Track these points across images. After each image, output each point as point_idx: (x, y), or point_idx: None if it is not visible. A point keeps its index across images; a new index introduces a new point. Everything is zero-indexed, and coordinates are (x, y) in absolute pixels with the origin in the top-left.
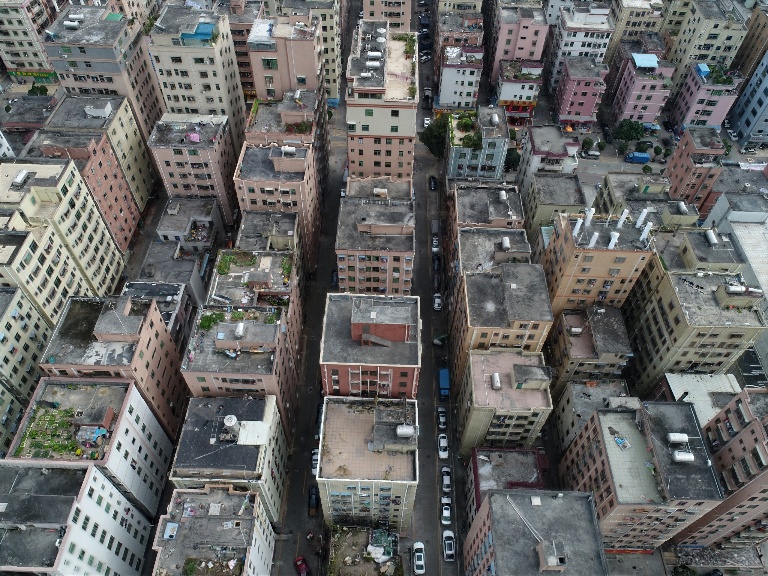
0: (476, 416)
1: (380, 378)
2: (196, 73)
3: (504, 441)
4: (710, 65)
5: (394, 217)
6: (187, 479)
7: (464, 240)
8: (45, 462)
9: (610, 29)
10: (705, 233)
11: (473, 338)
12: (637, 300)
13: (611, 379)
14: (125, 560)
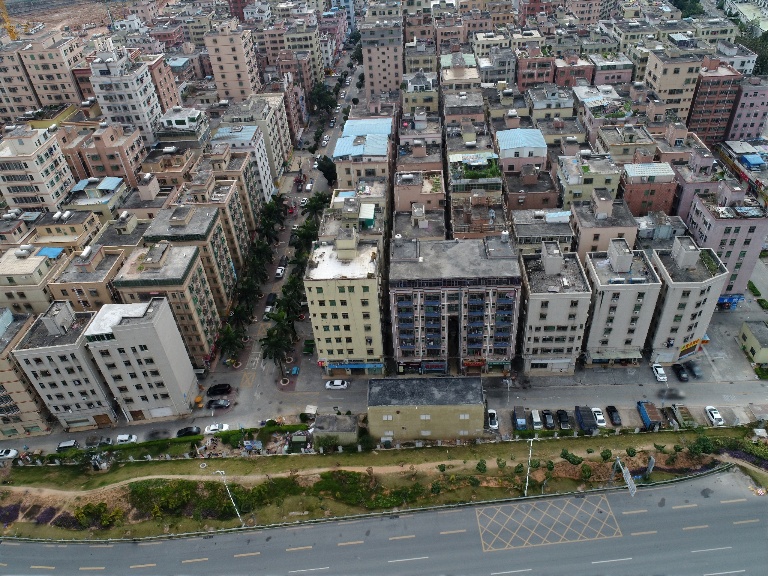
0: None
1: None
2: None
3: None
4: None
5: None
6: None
7: None
8: None
9: None
10: None
11: None
12: None
13: None
14: None
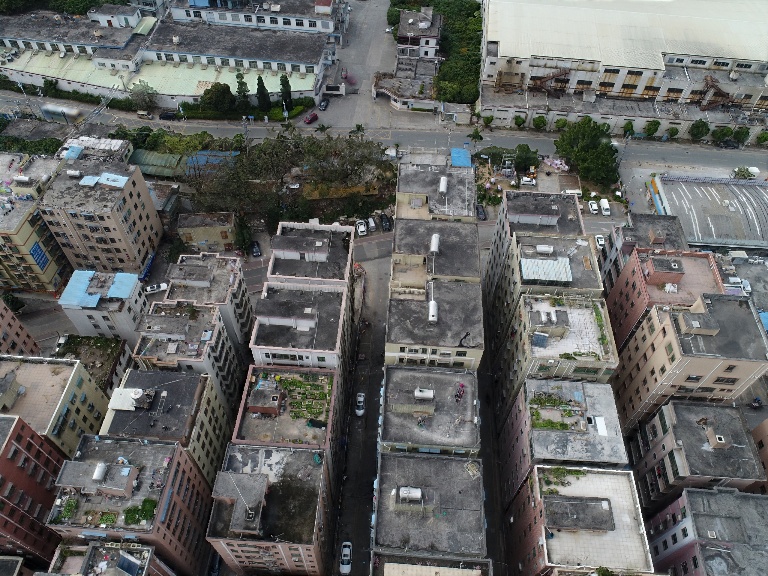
0: None
1: None
2: None
3: None
4: None
5: None
6: None
7: None
8: (289, 348)
9: None
10: None
11: None
12: None
13: None
14: None
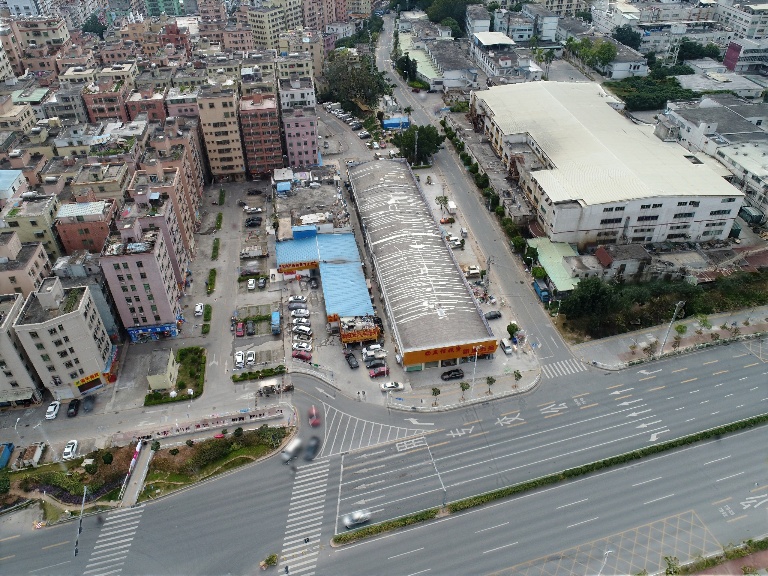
0: None
1: None
2: (2, 58)
3: None
4: None
5: None
6: None
7: None
8: None
9: None
10: None
11: None
12: None
13: None
14: None
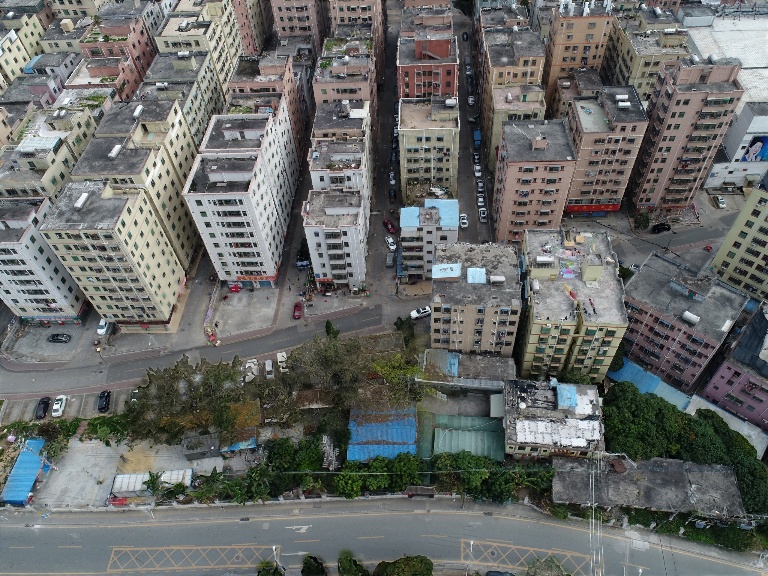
0: (497, 121)
1: (434, 78)
2: None
3: None
4: None
5: (438, 12)
6: (321, 138)
7: (487, 36)
8: (245, 114)
9: None
10: (654, 10)
11: (494, 79)
12: (612, 71)
13: None
14: (283, 200)
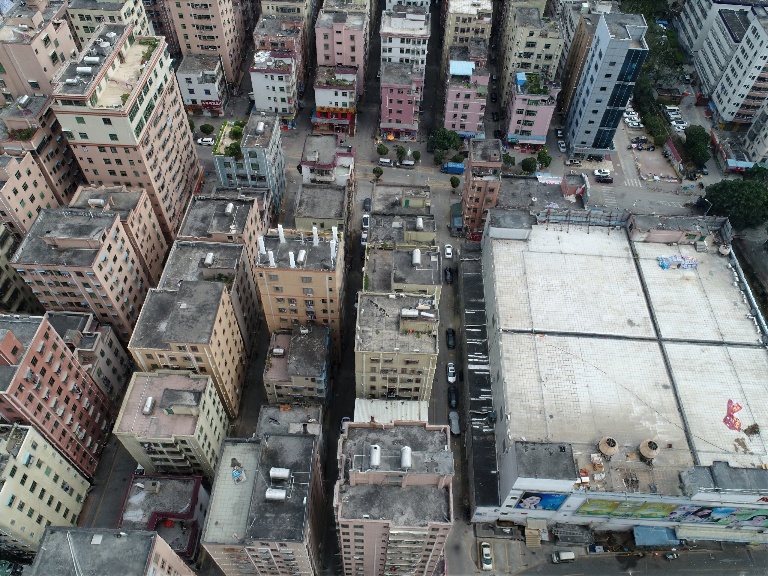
0: (125, 442)
1: None
2: None
3: (175, 467)
4: (533, 74)
5: (82, 230)
6: None
7: (180, 254)
8: None
9: (424, 35)
10: (412, 252)
11: (141, 359)
12: None
13: (306, 403)
14: None
